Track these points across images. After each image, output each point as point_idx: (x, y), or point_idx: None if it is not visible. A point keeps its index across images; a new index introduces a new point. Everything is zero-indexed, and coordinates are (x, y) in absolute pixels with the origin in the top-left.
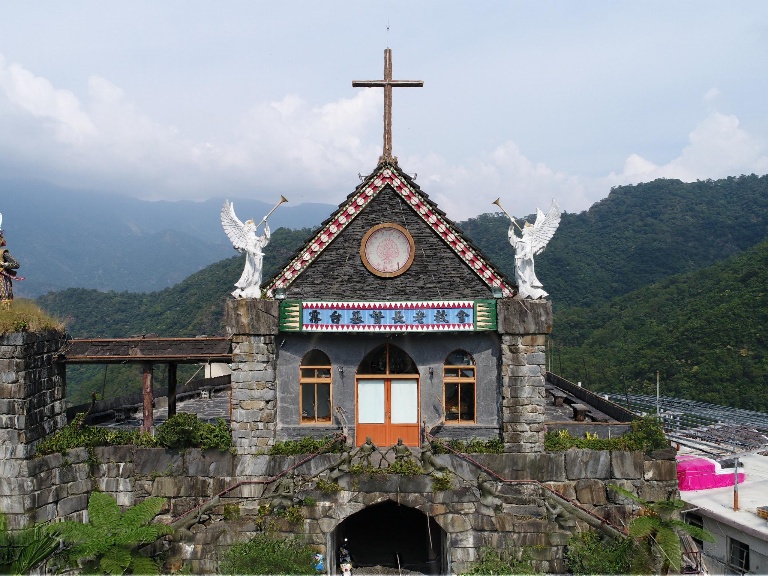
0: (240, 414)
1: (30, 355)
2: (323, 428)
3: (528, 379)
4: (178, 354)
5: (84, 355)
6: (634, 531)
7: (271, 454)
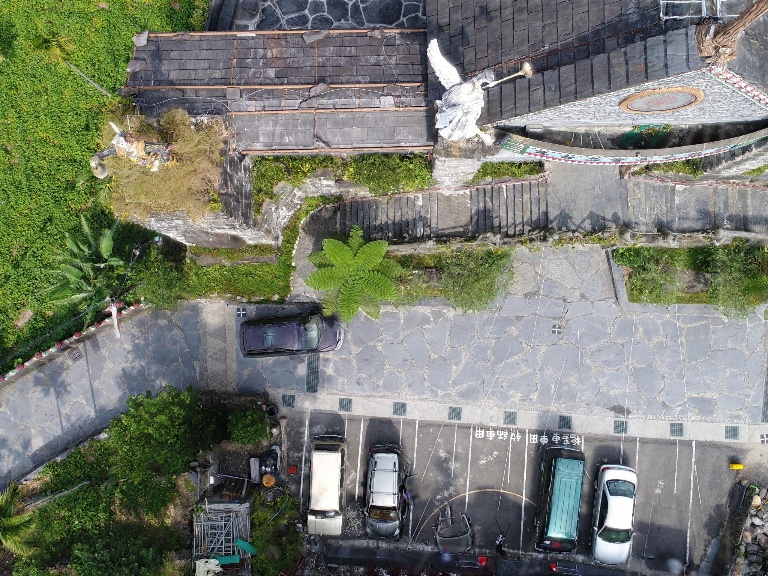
0: (442, 172)
1: (228, 202)
2: (523, 157)
3: (762, 159)
4: (369, 140)
5: (261, 143)
6: (767, 317)
7: (470, 181)
